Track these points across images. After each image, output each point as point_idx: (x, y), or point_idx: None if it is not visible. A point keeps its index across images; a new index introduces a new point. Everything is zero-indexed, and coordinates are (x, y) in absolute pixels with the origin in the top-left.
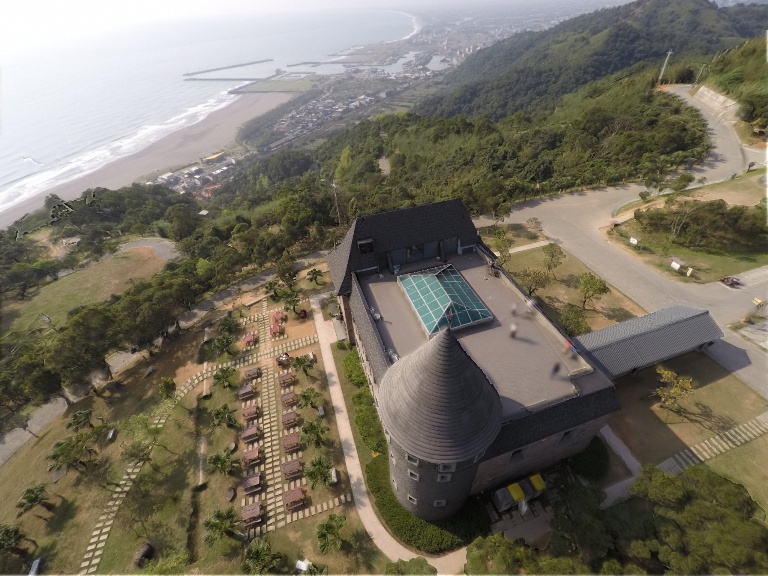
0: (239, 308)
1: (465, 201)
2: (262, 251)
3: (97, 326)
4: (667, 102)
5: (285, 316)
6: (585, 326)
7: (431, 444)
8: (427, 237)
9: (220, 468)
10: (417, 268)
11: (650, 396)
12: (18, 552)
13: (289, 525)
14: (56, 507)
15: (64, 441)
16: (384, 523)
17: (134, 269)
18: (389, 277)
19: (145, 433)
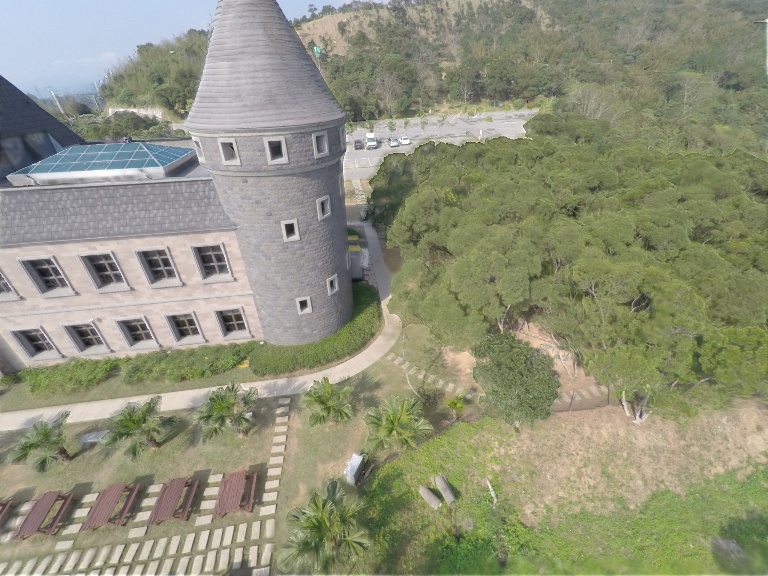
0: None
1: None
2: None
3: None
4: (93, 122)
5: None
6: None
7: (323, 97)
8: None
9: None
10: None
11: None
12: None
13: (279, 509)
14: None
15: None
16: (336, 363)
17: None
18: None
19: None
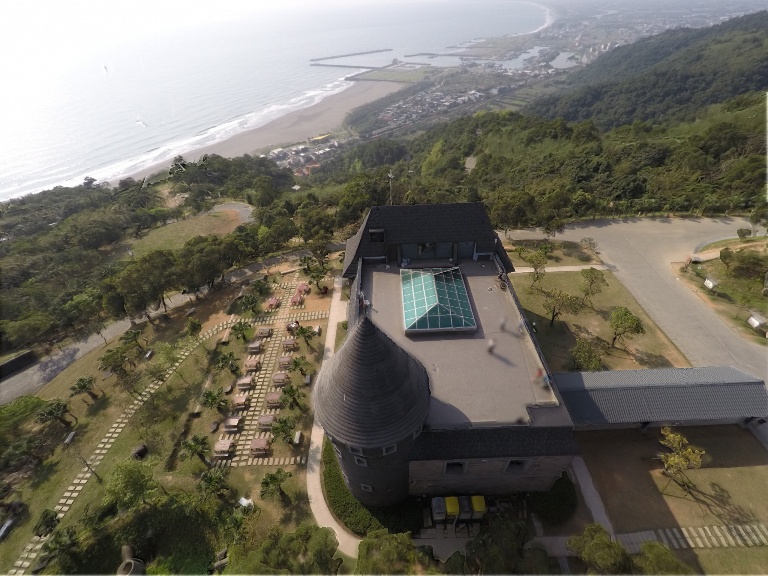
0: (275, 274)
1: (515, 209)
2: (309, 227)
3: (159, 265)
4: None
5: (309, 289)
6: (597, 363)
7: (340, 422)
8: (441, 236)
9: (210, 402)
10: (425, 266)
11: (654, 458)
12: (65, 423)
13: (248, 467)
14: (97, 398)
15: (113, 349)
16: (325, 492)
17: (219, 227)
18: (395, 269)
19: (164, 358)
